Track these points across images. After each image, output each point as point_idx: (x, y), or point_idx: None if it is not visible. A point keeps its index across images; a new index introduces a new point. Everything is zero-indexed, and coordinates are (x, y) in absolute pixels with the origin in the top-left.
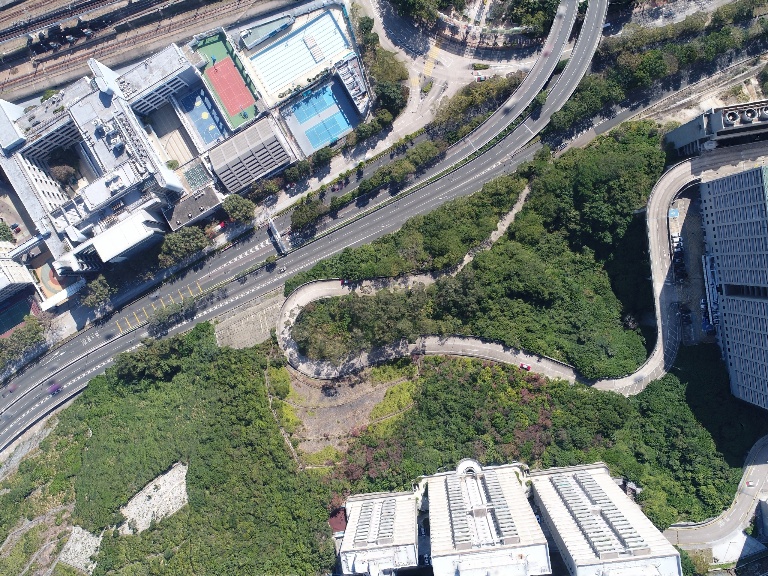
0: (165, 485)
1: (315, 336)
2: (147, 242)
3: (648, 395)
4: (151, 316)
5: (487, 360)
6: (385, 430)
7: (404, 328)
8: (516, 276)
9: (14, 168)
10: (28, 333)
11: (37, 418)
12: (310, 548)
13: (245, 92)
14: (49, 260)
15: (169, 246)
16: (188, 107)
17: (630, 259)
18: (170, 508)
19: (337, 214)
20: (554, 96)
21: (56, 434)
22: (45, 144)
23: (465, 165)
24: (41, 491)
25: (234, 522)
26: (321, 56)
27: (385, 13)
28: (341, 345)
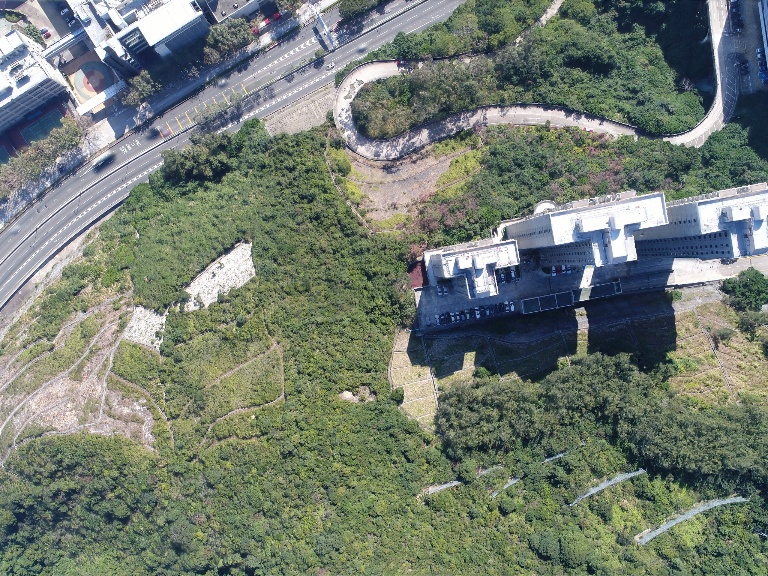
0: (229, 263)
1: (375, 114)
2: (192, 32)
3: (710, 145)
4: (197, 113)
5: None
6: (455, 192)
7: (472, 83)
8: (573, 47)
9: None
10: (66, 135)
11: (75, 233)
12: (389, 302)
13: None
14: (83, 66)
15: (215, 37)
16: None
17: (683, 24)
18: (237, 282)
19: (384, 9)
20: None
21: (100, 240)
22: None
23: None
24: (92, 287)
25: (308, 285)
26: None
27: None
28: None
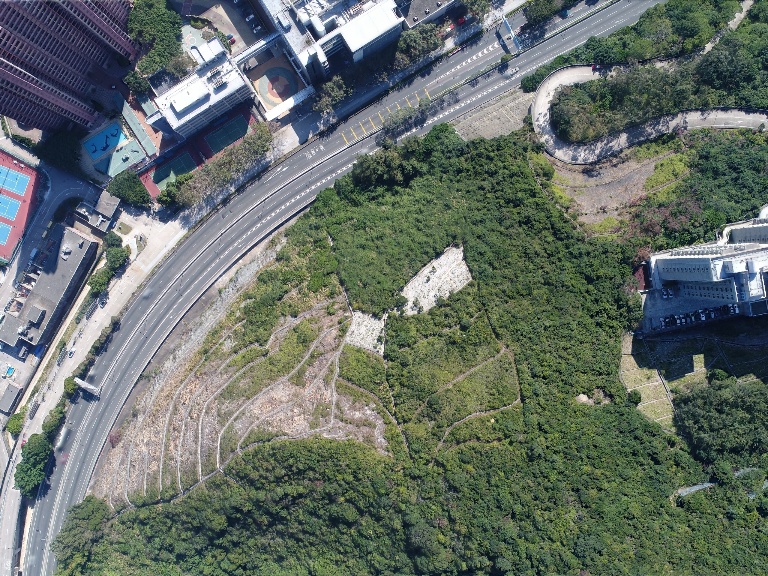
0: (441, 268)
1: None
2: (387, 37)
3: None
4: (387, 118)
5: None
6: (667, 195)
7: (688, 88)
8: None
9: None
10: (259, 141)
11: (260, 238)
12: (615, 305)
13: None
14: (267, 72)
15: (408, 42)
16: None
17: None
18: (454, 286)
19: (566, 13)
20: None
21: (293, 245)
22: None
23: None
24: (297, 292)
25: (530, 289)
26: None
27: None
28: (601, 126)
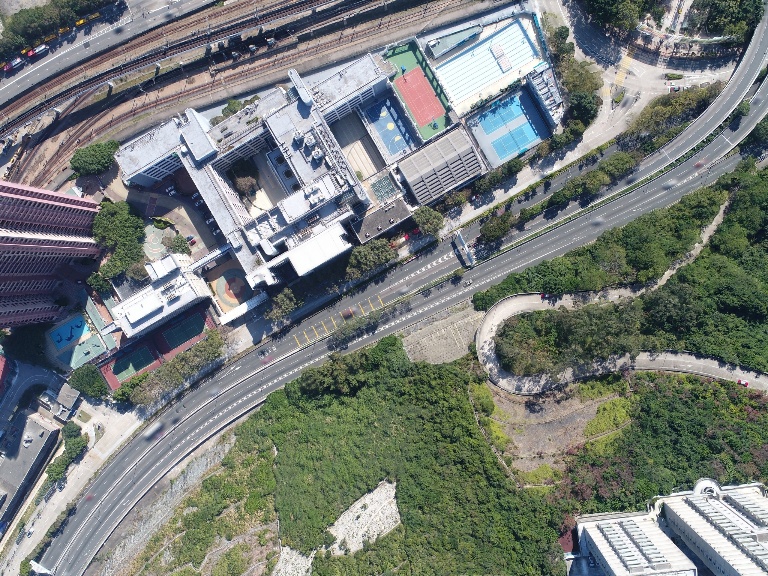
0: (373, 504)
1: None
2: None
3: None
4: (337, 330)
5: (701, 376)
6: (605, 448)
7: (629, 344)
8: (727, 290)
9: (205, 180)
10: (210, 347)
11: (211, 434)
12: (539, 570)
13: (435, 102)
14: (225, 273)
15: (359, 259)
16: (373, 117)
17: None
18: (382, 528)
19: (524, 226)
20: (754, 107)
21: (239, 450)
22: (233, 155)
23: (660, 177)
24: (235, 510)
25: (456, 543)
26: (509, 66)
27: (576, 22)
28: (546, 360)
